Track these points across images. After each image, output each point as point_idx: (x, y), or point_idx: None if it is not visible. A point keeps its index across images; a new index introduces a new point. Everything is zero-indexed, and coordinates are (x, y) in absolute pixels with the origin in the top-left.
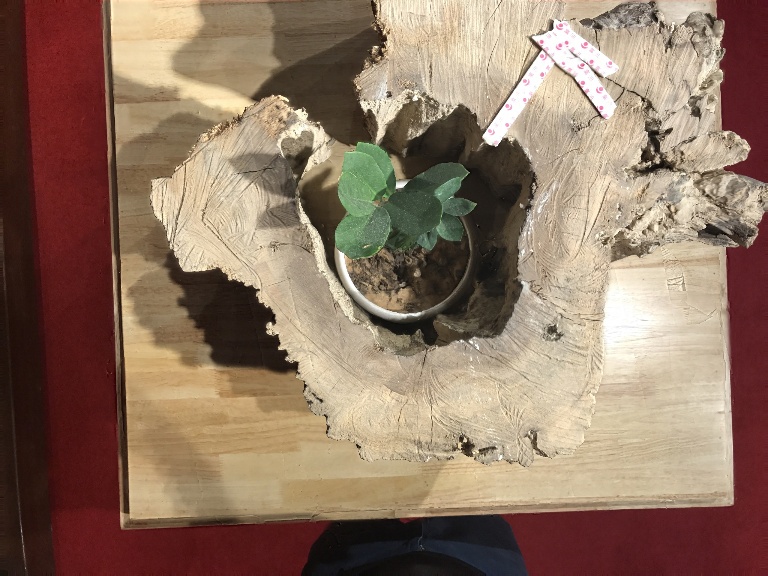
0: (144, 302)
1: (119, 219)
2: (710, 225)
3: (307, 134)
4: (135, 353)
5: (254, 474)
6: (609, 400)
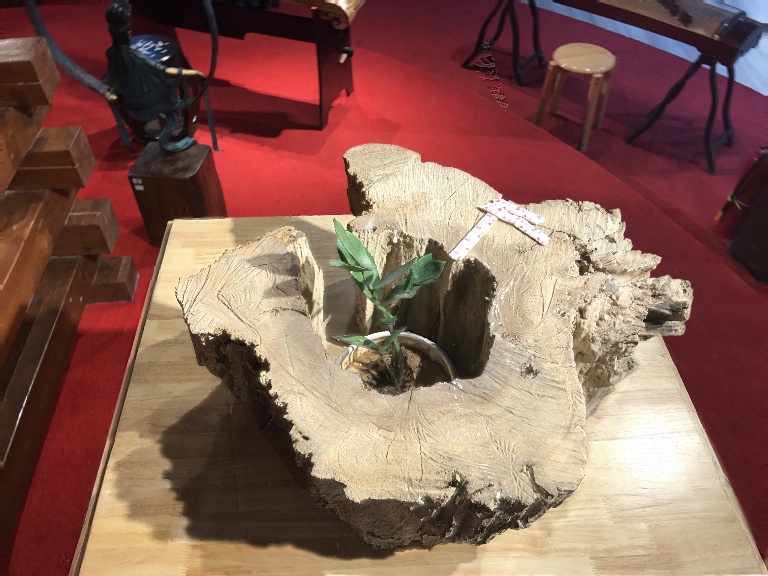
0: (128, 475)
1: (124, 404)
2: (652, 314)
3: (310, 270)
4: (103, 530)
5: None
6: (631, 575)
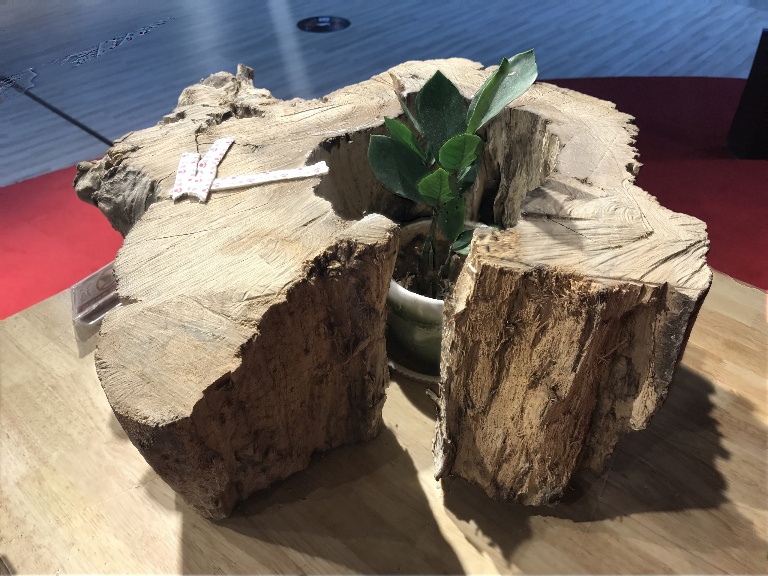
0: None
1: None
2: None
3: None
4: None
5: (719, 299)
6: None
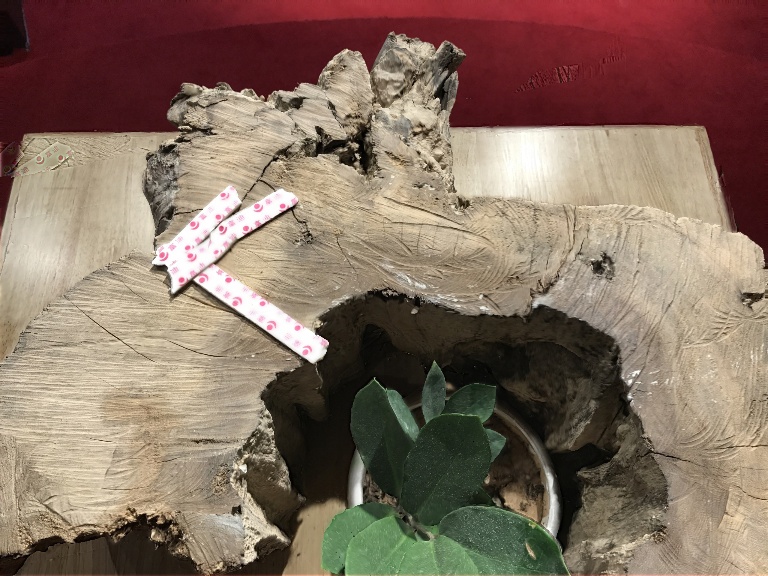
0: None
1: None
2: None
3: None
4: None
5: None
6: None
